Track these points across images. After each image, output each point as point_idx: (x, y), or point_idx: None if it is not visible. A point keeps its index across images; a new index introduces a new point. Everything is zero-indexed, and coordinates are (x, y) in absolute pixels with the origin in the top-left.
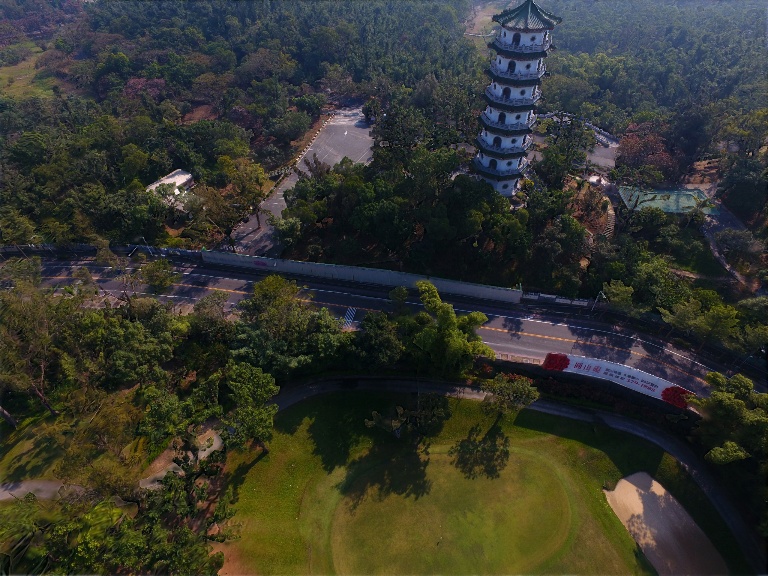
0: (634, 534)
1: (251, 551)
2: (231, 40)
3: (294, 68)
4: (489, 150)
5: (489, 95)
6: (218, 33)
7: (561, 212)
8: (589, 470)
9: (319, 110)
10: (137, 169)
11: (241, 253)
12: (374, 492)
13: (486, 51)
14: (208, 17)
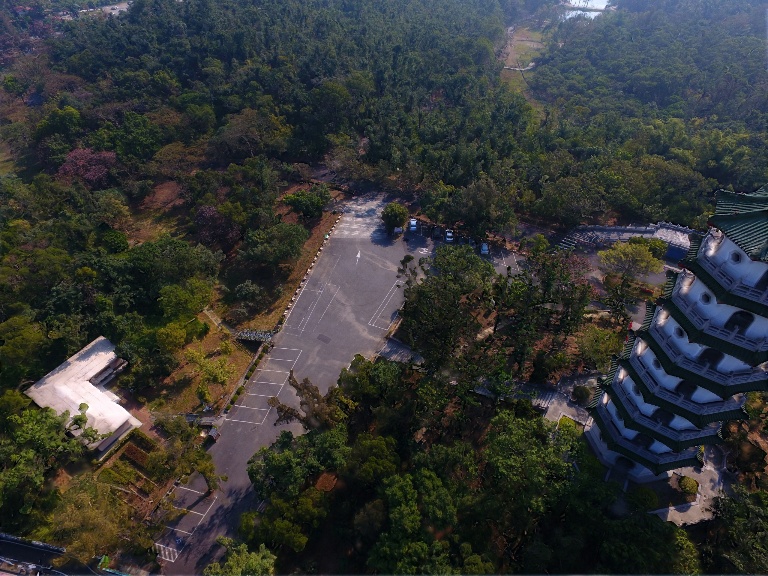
0: None
1: None
2: (212, 88)
3: (289, 136)
4: (644, 426)
5: (662, 343)
6: (198, 76)
7: None
8: None
9: (321, 207)
10: (23, 357)
11: (171, 567)
12: None
13: (527, 92)
14: (185, 57)
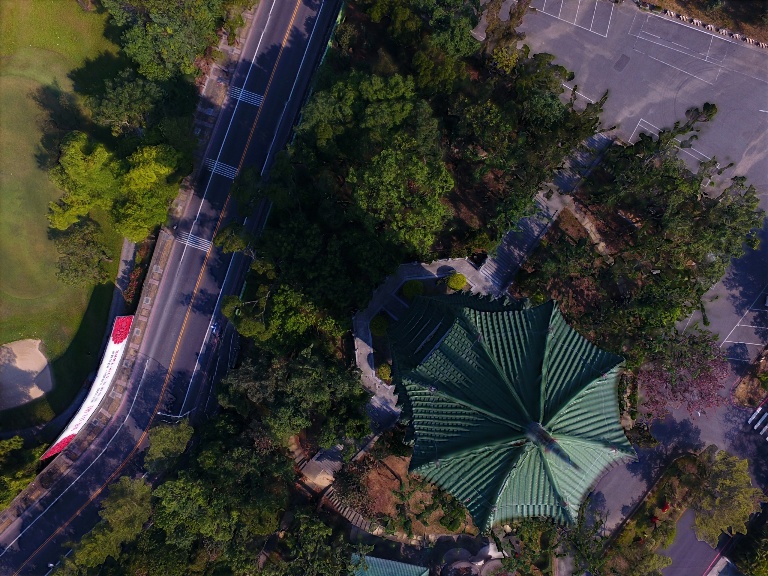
0: (1, 349)
1: (0, 4)
2: None
3: None
4: None
5: None
6: None
7: (325, 422)
8: (52, 332)
9: None
10: None
11: None
12: (45, 116)
13: None
14: None
